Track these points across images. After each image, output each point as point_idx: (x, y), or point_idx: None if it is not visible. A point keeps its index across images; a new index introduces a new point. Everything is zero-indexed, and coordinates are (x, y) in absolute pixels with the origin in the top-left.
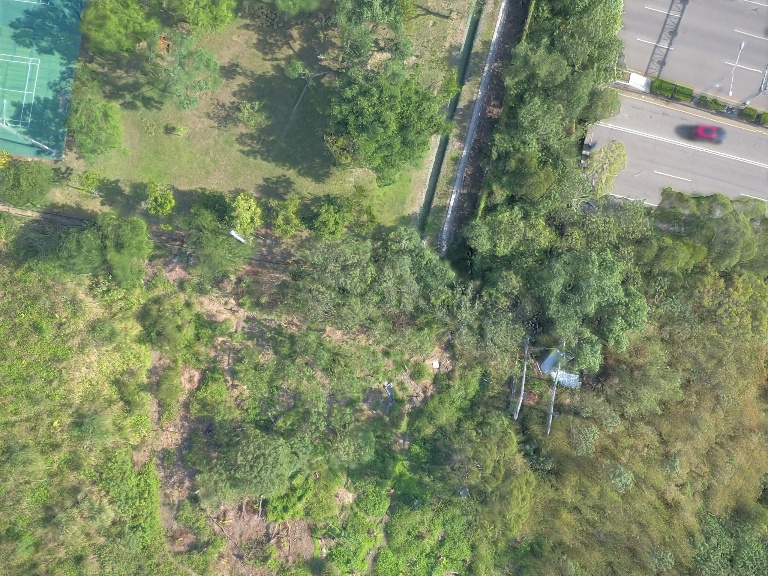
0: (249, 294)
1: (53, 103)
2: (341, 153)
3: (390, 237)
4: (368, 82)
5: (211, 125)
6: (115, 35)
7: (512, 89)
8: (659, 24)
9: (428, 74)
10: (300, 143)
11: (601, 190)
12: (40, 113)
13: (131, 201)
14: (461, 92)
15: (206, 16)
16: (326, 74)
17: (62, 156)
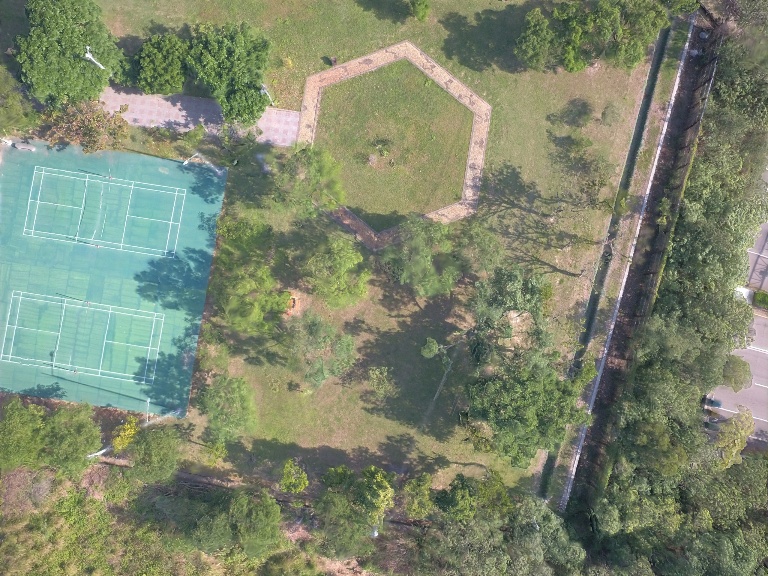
0: (374, 560)
1: (178, 360)
2: (480, 441)
3: (521, 514)
4: (510, 373)
5: (336, 382)
6: (257, 326)
7: (642, 356)
8: (763, 234)
9: (555, 333)
10: (425, 402)
11: (731, 462)
12: (165, 370)
13: (255, 460)
14: (587, 350)
15: (344, 295)
16: (452, 332)
17: (186, 414)
